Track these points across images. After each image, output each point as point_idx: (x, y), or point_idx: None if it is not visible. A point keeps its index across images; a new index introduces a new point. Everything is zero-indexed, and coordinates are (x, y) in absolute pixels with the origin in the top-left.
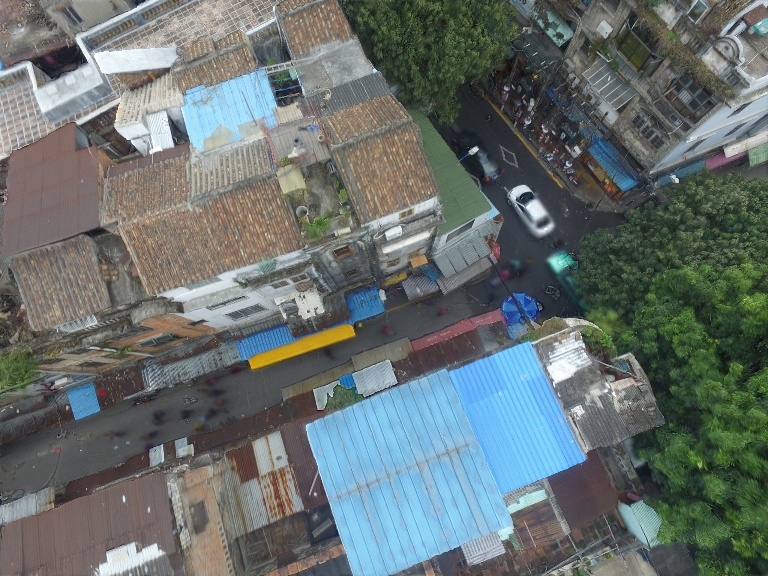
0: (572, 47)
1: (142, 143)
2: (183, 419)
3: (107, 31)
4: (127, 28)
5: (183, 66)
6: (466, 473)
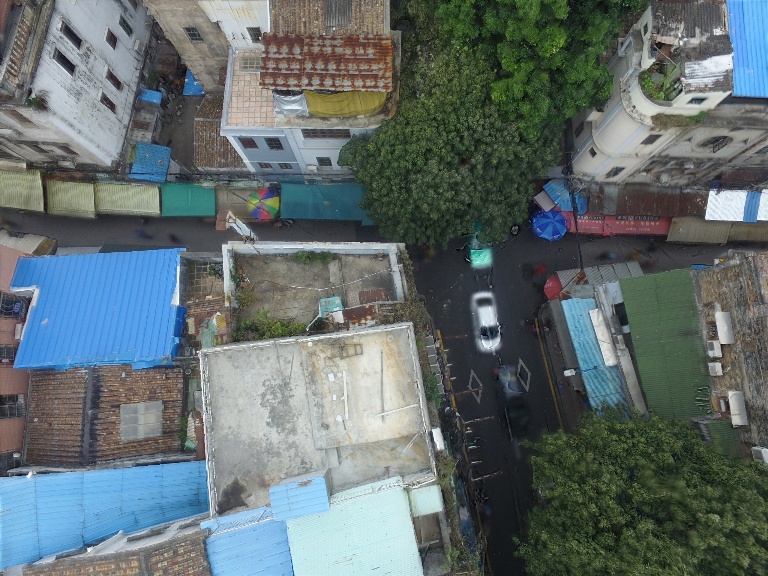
0: None
1: None
2: None
3: None
4: None
5: None
6: None
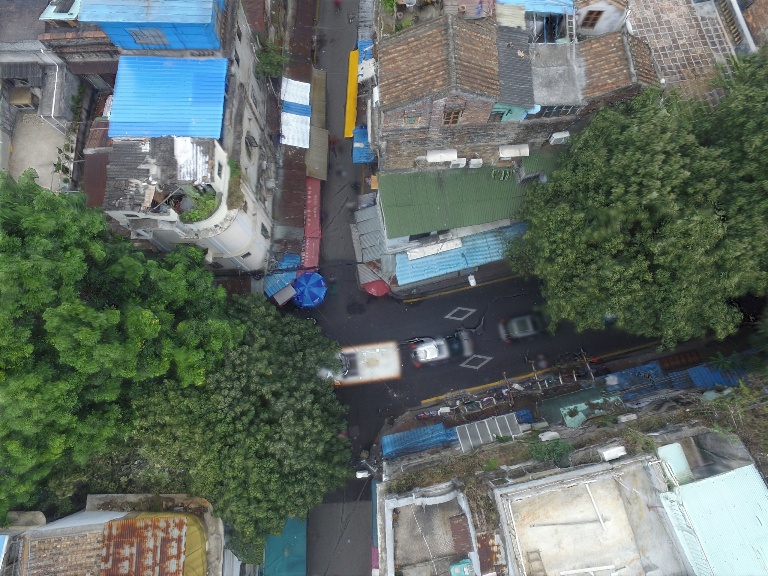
0: None
1: None
2: (339, 10)
3: None
4: None
5: None
6: (128, 6)
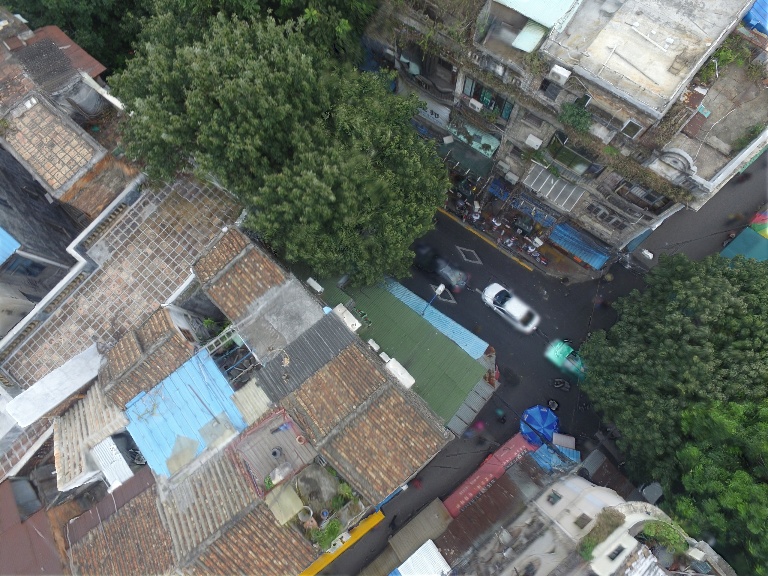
0: (501, 151)
1: (95, 478)
2: None
3: (10, 344)
4: (31, 329)
5: (113, 382)
6: None
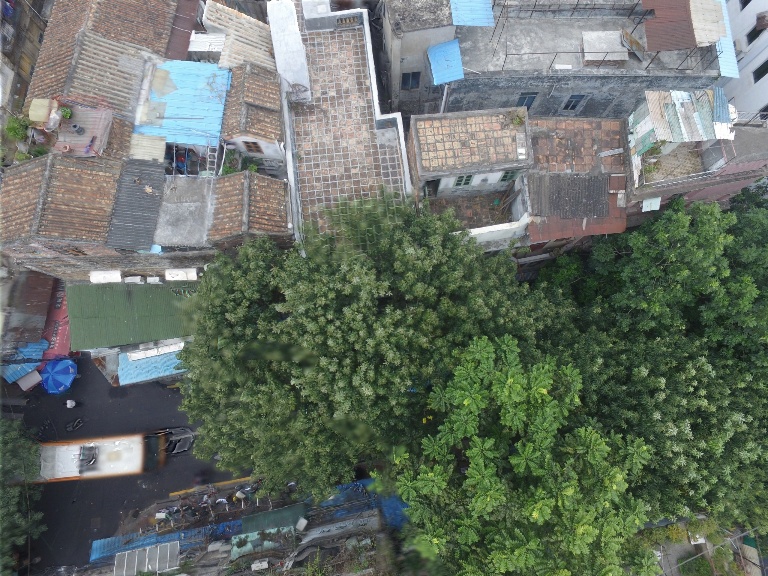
0: None
1: None
2: None
3: None
4: None
5: None
6: None
